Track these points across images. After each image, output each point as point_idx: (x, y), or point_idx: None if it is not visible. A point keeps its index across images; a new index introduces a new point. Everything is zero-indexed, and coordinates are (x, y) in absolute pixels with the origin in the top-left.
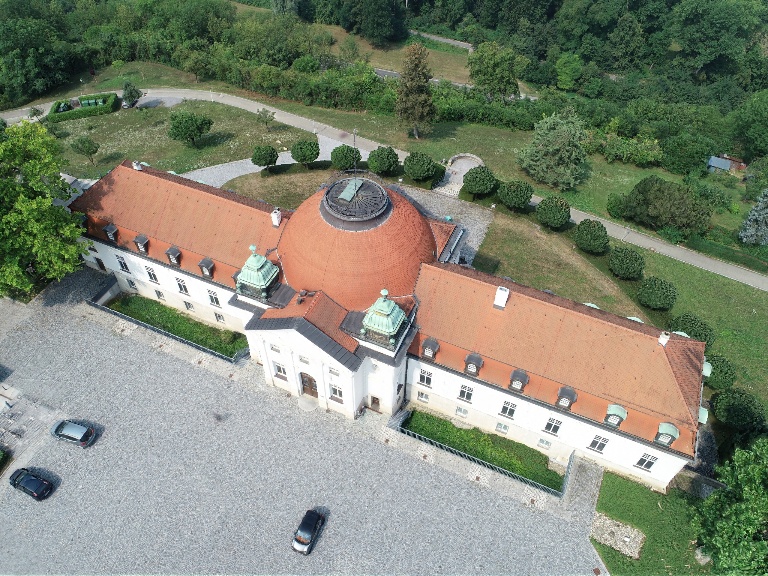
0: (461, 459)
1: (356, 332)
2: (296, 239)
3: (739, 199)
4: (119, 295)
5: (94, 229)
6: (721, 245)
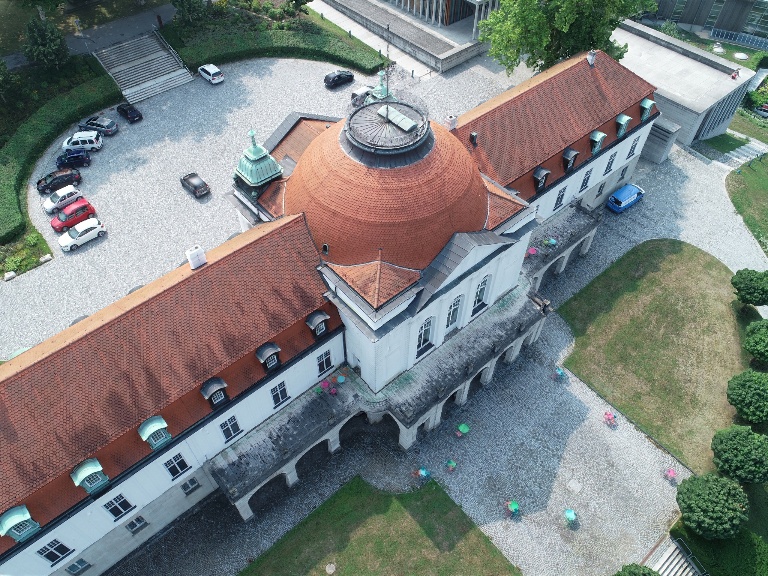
0: None
1: None
2: None
3: None
4: None
5: None
6: None
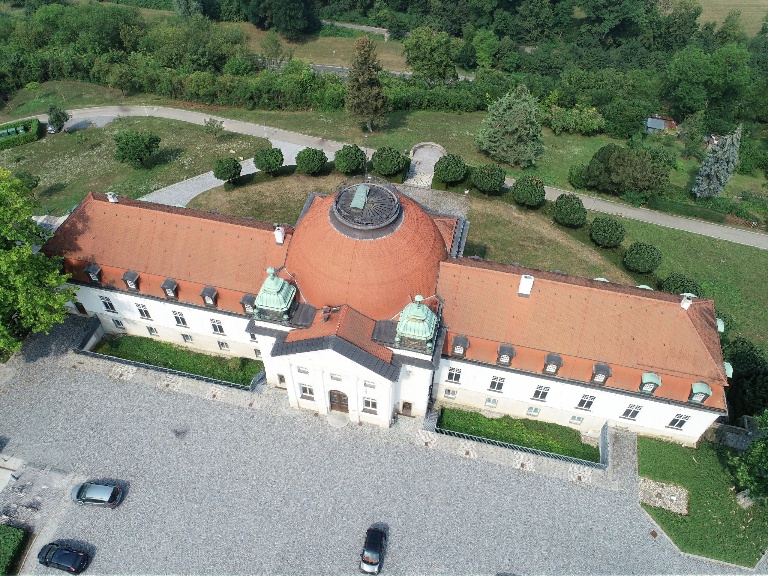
0: (503, 449)
1: (389, 341)
2: (310, 255)
3: (680, 156)
4: (104, 337)
5: (72, 272)
6: (680, 202)
